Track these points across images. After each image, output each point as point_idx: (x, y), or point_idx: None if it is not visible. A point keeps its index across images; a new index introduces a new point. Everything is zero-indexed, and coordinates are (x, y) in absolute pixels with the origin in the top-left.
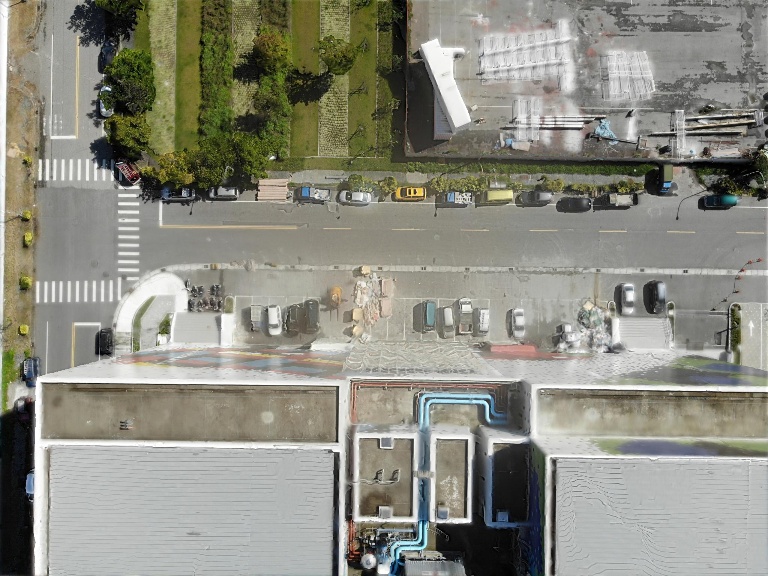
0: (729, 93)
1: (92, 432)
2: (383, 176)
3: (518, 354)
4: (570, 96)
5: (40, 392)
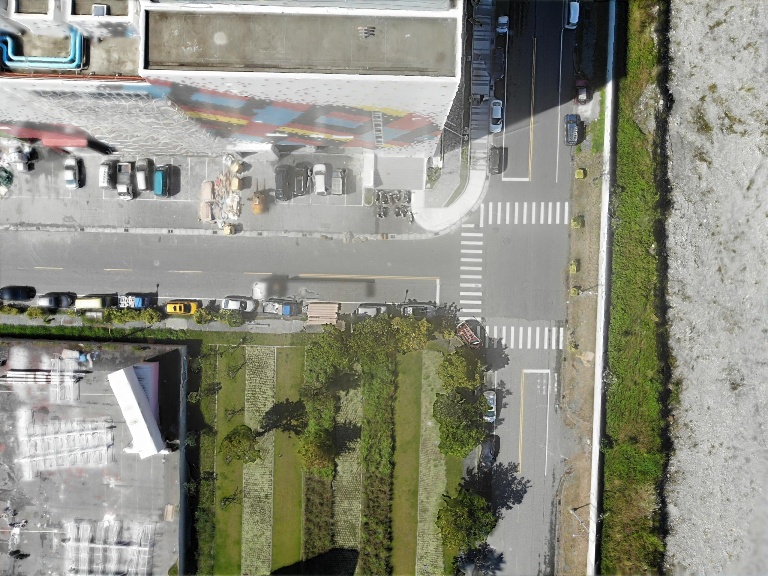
0: None
1: (405, 25)
2: (212, 326)
3: (54, 134)
4: (23, 404)
5: (458, 67)
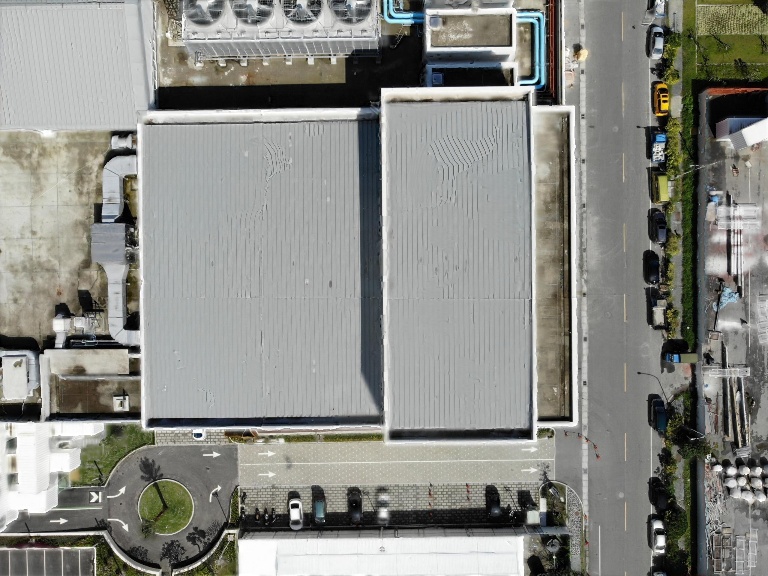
0: (767, 422)
1: None
2: None
3: None
4: (762, 261)
5: None
